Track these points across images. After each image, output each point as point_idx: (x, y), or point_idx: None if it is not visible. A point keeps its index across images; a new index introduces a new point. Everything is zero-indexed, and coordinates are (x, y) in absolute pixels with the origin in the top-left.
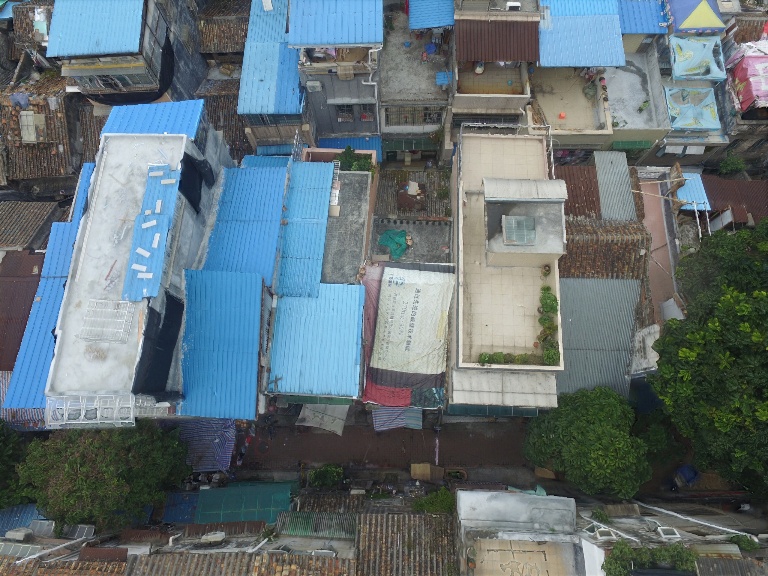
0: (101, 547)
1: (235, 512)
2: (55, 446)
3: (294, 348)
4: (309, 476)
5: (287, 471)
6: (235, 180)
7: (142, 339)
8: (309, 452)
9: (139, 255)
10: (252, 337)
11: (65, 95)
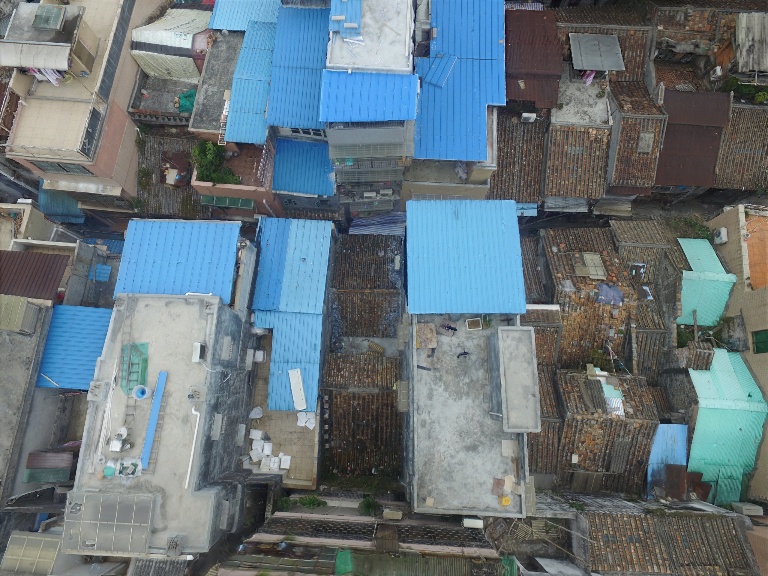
0: None
1: None
2: None
3: None
4: None
5: None
6: (318, 113)
7: None
8: None
9: None
10: None
11: (556, 295)
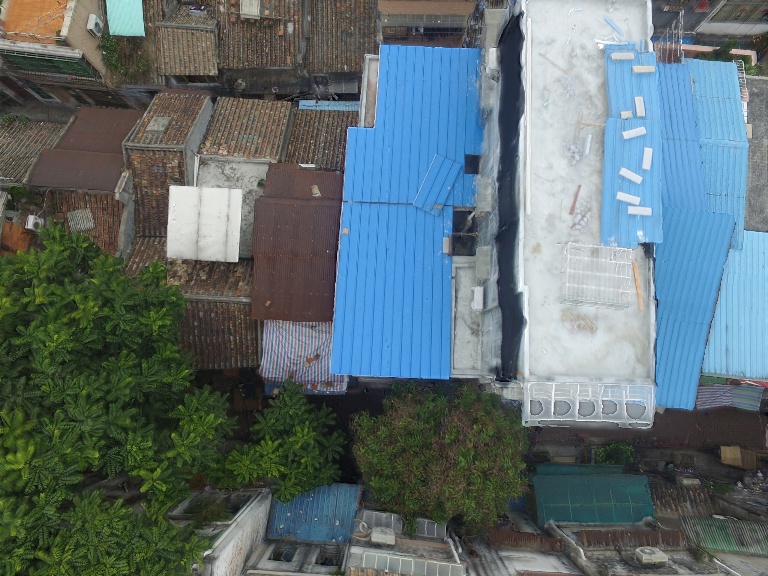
0: (550, 572)
1: (586, 506)
2: (403, 425)
3: (715, 315)
4: (596, 453)
5: (562, 445)
6: None
7: (654, 305)
8: (586, 425)
9: (625, 179)
10: (707, 302)
11: None
